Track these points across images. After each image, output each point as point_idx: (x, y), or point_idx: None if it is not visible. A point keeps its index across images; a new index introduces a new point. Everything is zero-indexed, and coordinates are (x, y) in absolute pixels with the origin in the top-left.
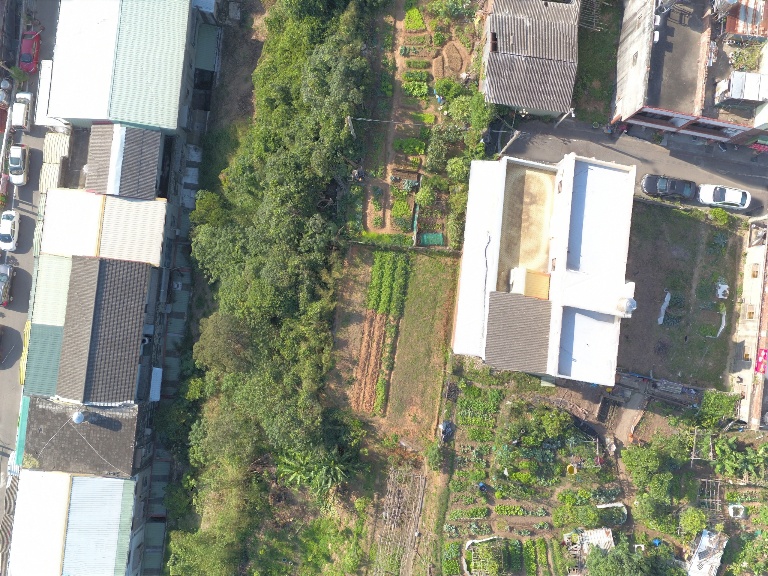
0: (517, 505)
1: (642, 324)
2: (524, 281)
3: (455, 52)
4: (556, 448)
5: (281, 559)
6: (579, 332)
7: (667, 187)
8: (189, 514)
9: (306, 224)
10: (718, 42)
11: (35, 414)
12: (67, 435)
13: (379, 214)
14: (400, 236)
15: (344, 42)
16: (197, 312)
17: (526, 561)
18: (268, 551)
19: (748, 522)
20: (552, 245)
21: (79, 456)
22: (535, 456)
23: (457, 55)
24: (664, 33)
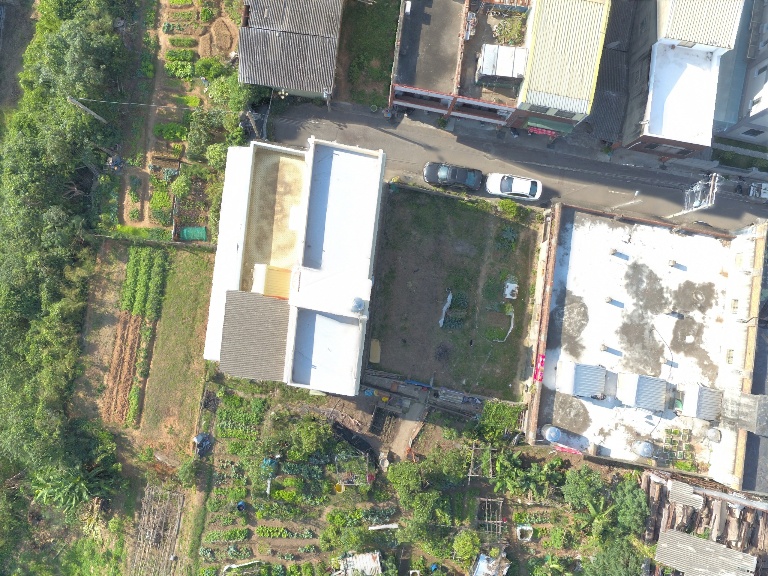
0: (281, 526)
1: (422, 327)
2: (264, 279)
3: (224, 29)
4: (324, 463)
5: None
6: (320, 335)
7: (448, 176)
8: None
9: None
10: (478, 13)
11: None
12: None
13: (136, 206)
14: (158, 230)
15: (94, 17)
16: None
17: None
18: (22, 575)
19: (538, 546)
20: None
21: None
22: (301, 472)
23: (226, 32)
24: (421, 4)
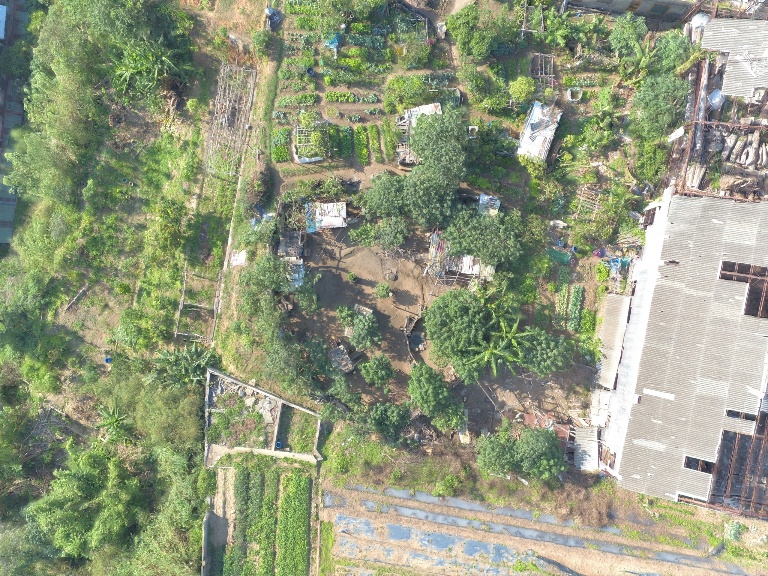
0: (348, 91)
1: None
2: None
3: None
4: (386, 33)
5: (121, 180)
6: None
7: None
8: None
9: None
10: None
11: None
12: None
13: None
14: None
15: None
16: None
17: (357, 146)
18: (106, 168)
19: (588, 106)
20: None
21: None
22: (365, 42)
23: None
24: None
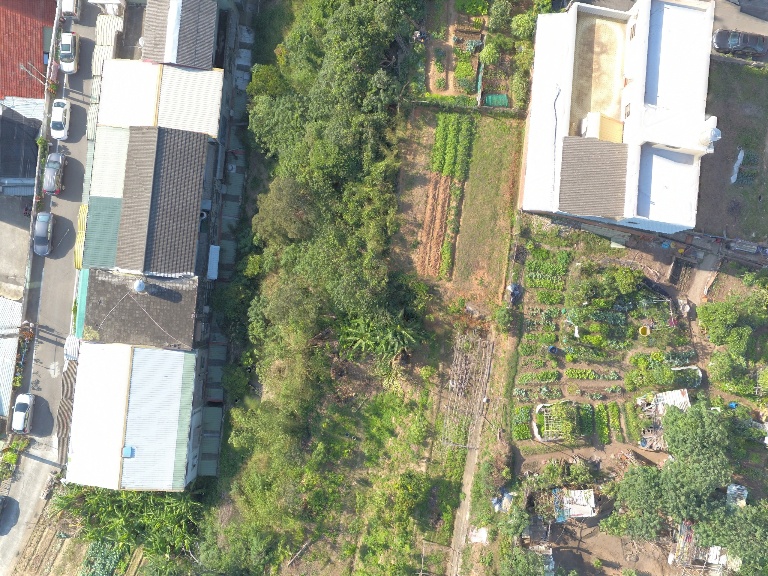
0: (588, 368)
1: (714, 183)
2: (598, 125)
3: None
4: (627, 310)
5: (344, 434)
6: (657, 174)
7: (739, 40)
8: (247, 396)
9: (370, 81)
10: None
11: (95, 286)
12: (127, 307)
13: (442, 76)
14: (464, 97)
15: None
16: (252, 193)
17: (598, 425)
18: (331, 425)
19: None
20: (624, 95)
21: (139, 328)
22: (606, 318)
23: None
24: None
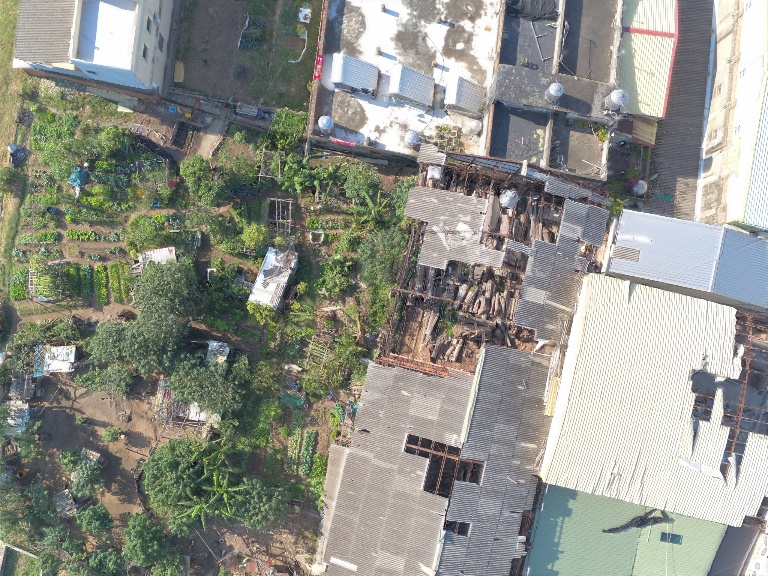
0: (89, 230)
1: (222, 49)
2: None
3: None
4: (130, 172)
5: None
6: (103, 21)
7: None
8: None
9: None
10: None
11: None
12: None
13: None
14: None
15: None
16: None
17: (96, 286)
18: None
19: (329, 249)
20: None
21: None
22: (109, 181)
23: None
24: None
